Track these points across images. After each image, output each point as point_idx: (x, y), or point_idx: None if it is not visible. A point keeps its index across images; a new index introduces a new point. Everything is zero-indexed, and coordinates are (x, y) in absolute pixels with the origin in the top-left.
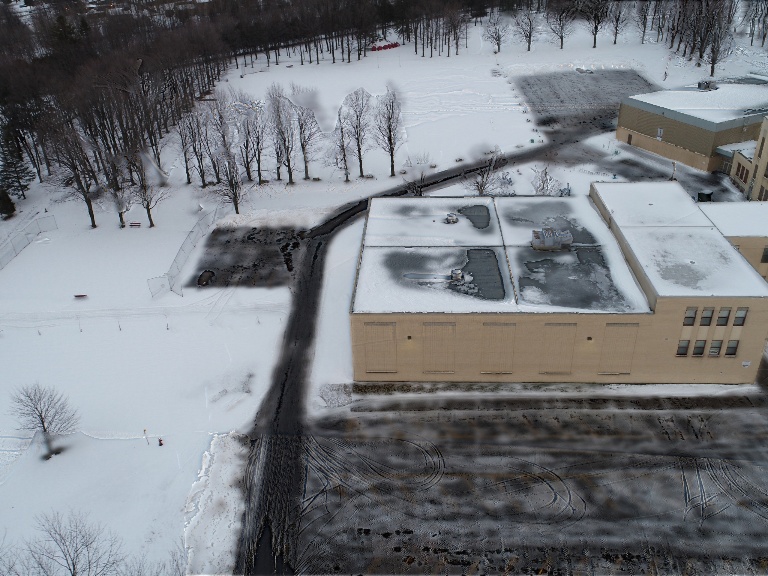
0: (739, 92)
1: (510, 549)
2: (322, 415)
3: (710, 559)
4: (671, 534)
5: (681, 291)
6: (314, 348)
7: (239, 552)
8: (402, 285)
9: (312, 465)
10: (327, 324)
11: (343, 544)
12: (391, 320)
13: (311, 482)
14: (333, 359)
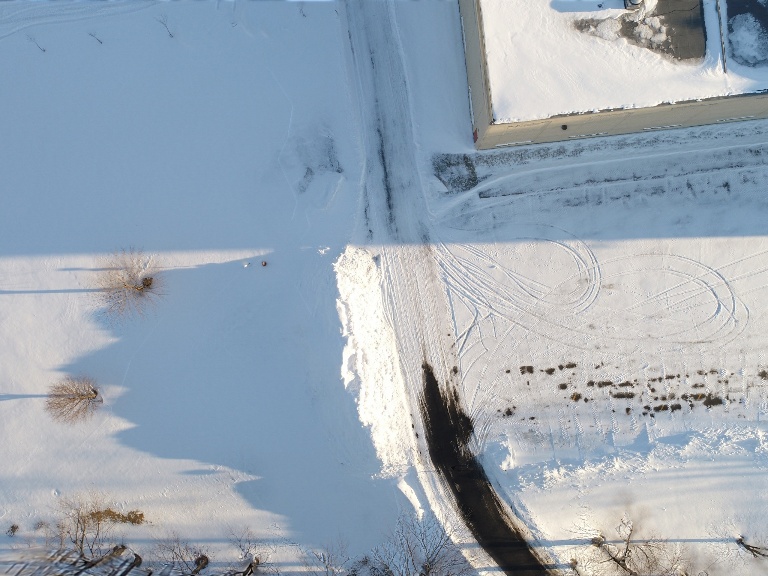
0: None
1: (672, 376)
2: (446, 208)
3: None
4: None
5: None
6: (401, 71)
7: (410, 406)
8: (552, 35)
9: (454, 288)
10: (408, 16)
11: (509, 386)
12: (546, 121)
13: (459, 312)
14: (438, 105)
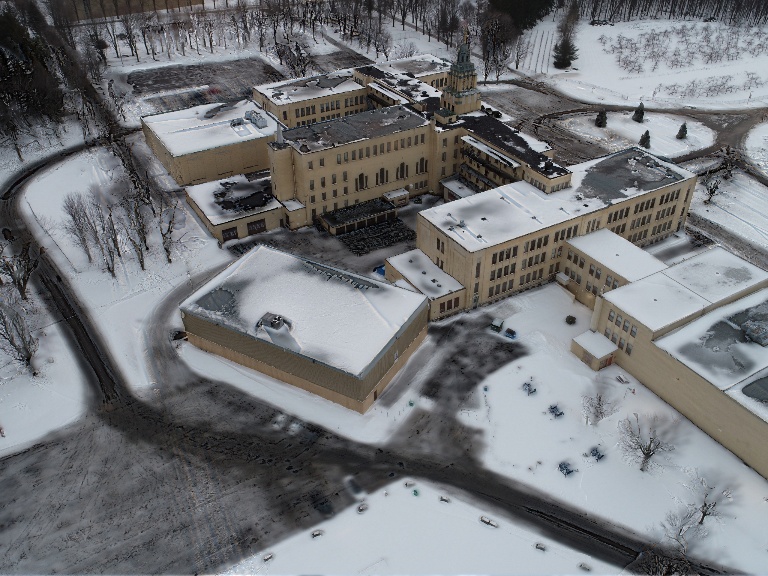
0: (284, 301)
1: None
2: None
3: None
4: None
5: (758, 271)
6: None
7: None
8: None
9: None
10: None
11: None
12: None
13: None
14: None
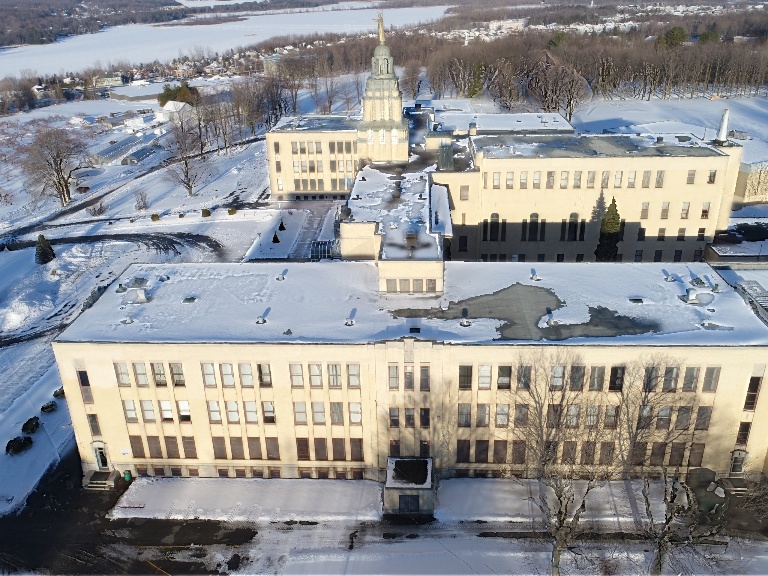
0: None
1: None
2: None
3: None
4: None
5: None
6: None
7: None
8: None
9: None
10: None
11: None
12: None
13: None
14: None
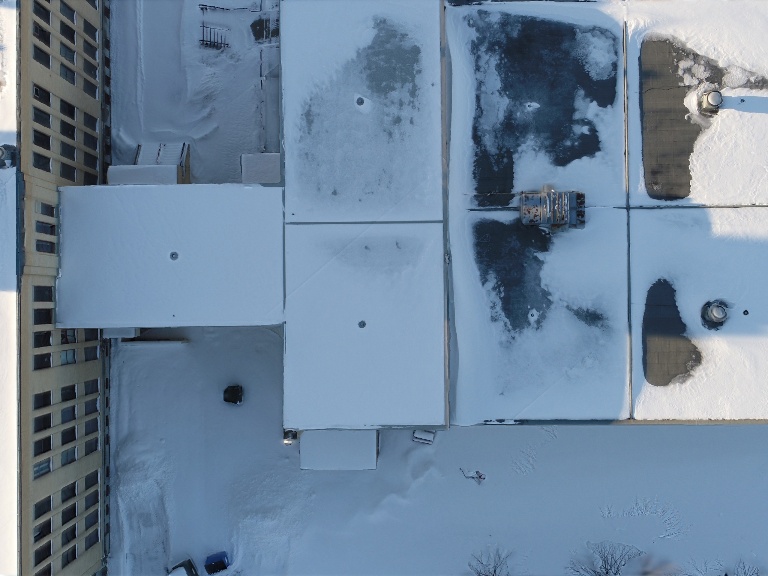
0: None
1: None
2: None
3: None
4: None
5: (407, 9)
6: None
7: None
8: None
9: None
10: None
11: None
12: None
13: None
14: None
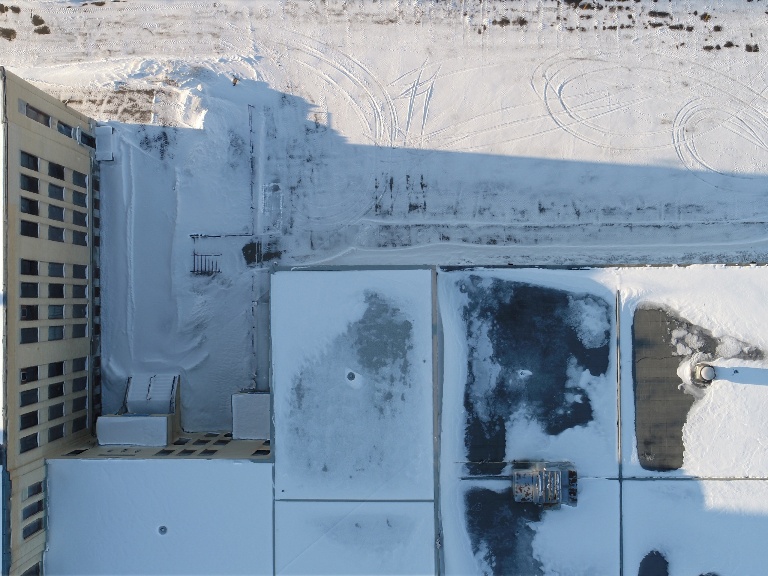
0: None
1: (612, 29)
2: None
3: (432, 21)
4: (459, 48)
5: (398, 284)
6: None
7: None
8: None
9: None
10: None
11: None
12: None
13: None
14: None
